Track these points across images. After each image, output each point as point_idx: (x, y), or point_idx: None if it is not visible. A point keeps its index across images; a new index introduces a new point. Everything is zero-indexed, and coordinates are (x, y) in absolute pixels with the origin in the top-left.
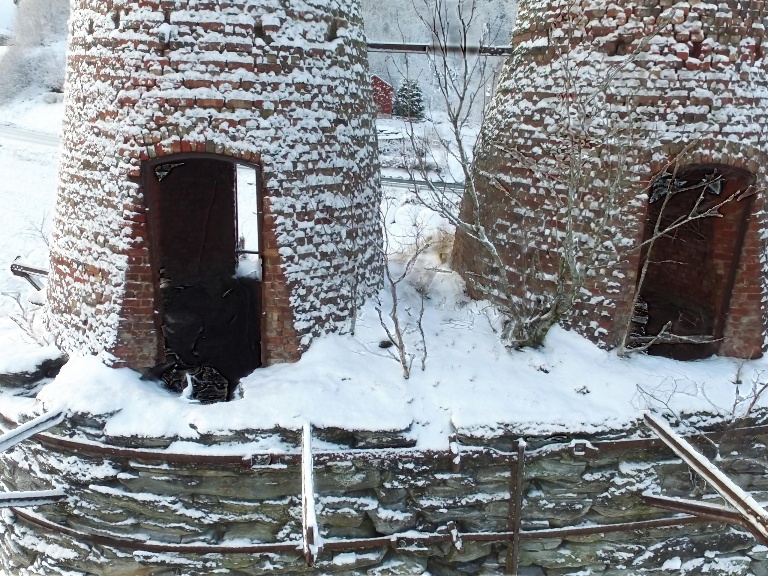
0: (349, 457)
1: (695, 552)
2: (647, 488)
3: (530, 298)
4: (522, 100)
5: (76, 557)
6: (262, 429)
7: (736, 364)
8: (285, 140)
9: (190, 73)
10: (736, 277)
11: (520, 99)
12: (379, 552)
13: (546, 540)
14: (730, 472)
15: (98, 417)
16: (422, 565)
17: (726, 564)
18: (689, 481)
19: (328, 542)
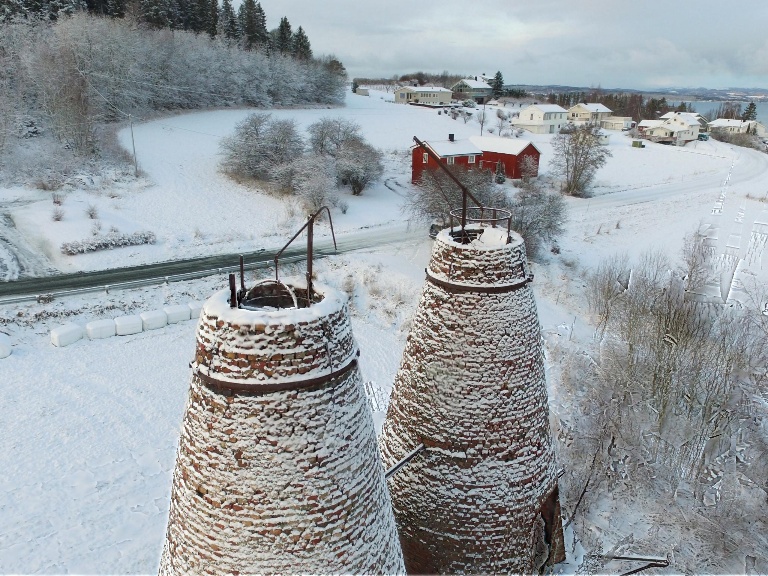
0: None
1: None
2: None
3: None
4: (454, 489)
5: None
6: None
7: (564, 573)
8: None
9: None
10: (553, 529)
11: (452, 488)
12: None
13: None
14: None
15: None
16: None
17: None
18: None
19: None
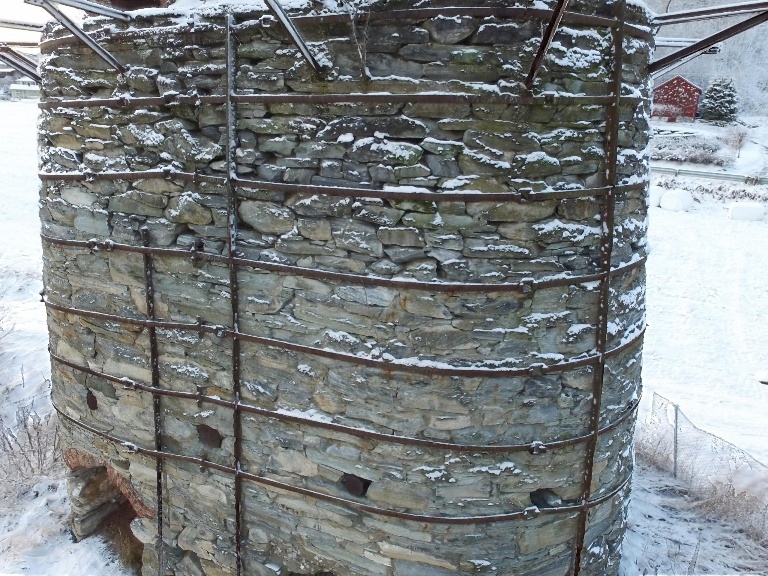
0: (141, 33)
1: (366, 131)
2: (319, 61)
3: None
4: None
5: (44, 120)
6: (107, 20)
7: None
8: None
9: None
10: None
11: None
12: (162, 113)
13: (253, 106)
14: (399, 58)
15: (52, 24)
16: (184, 125)
17: (394, 147)
18: (359, 62)
19: (133, 99)
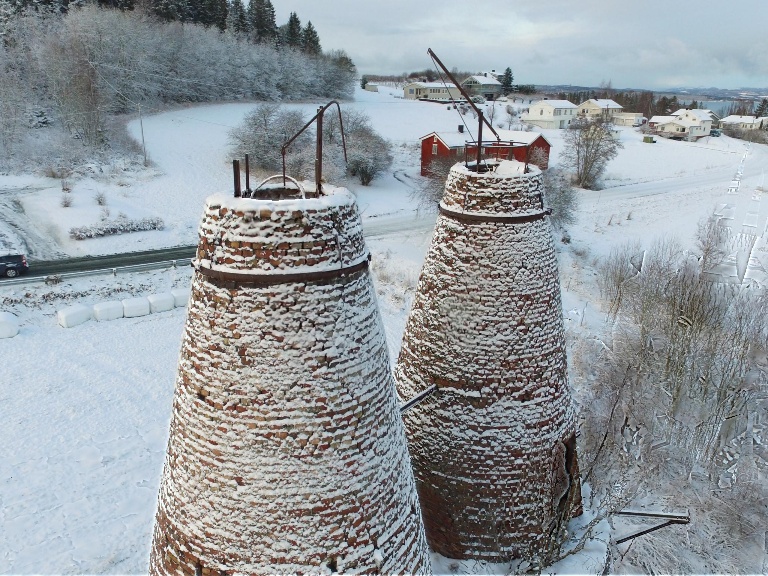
0: None
1: None
2: None
3: (504, 551)
4: (468, 430)
5: None
6: None
7: None
8: (427, 568)
9: (395, 574)
10: None
11: (466, 429)
12: None
13: None
14: None
15: None
16: None
17: None
18: None
19: None
